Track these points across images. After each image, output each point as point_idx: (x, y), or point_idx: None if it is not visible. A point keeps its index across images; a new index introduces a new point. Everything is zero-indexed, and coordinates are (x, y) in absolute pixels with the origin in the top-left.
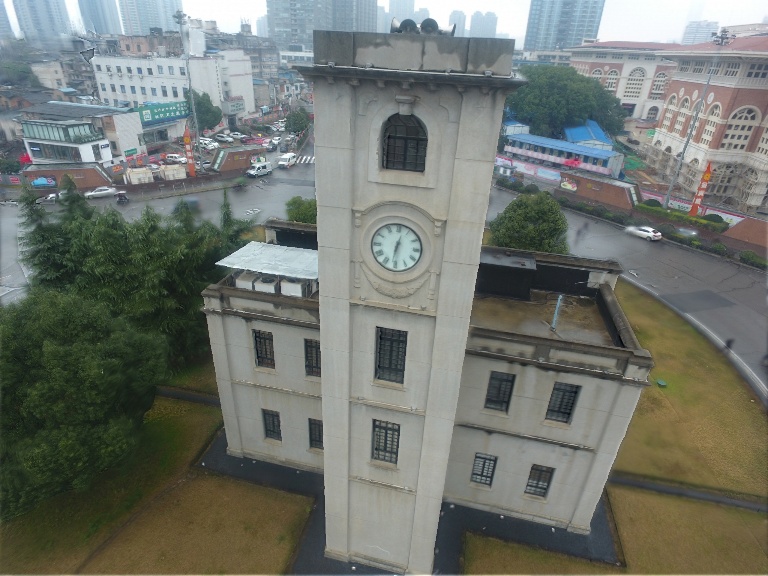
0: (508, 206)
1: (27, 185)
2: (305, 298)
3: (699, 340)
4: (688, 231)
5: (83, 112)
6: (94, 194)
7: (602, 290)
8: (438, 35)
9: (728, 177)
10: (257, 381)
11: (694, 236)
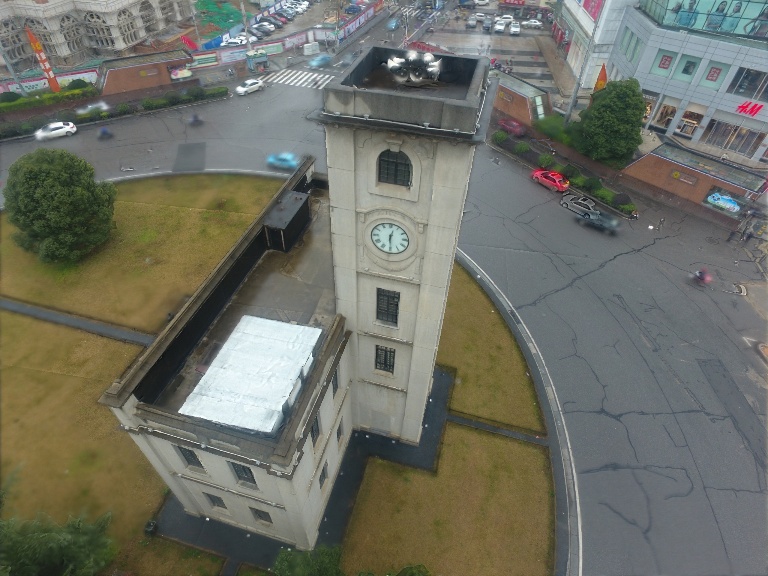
0: (20, 187)
1: None
2: (321, 353)
3: (243, 179)
4: (83, 107)
5: None
6: None
7: (319, 178)
8: (482, 72)
9: (14, 35)
10: (316, 463)
11: (96, 109)
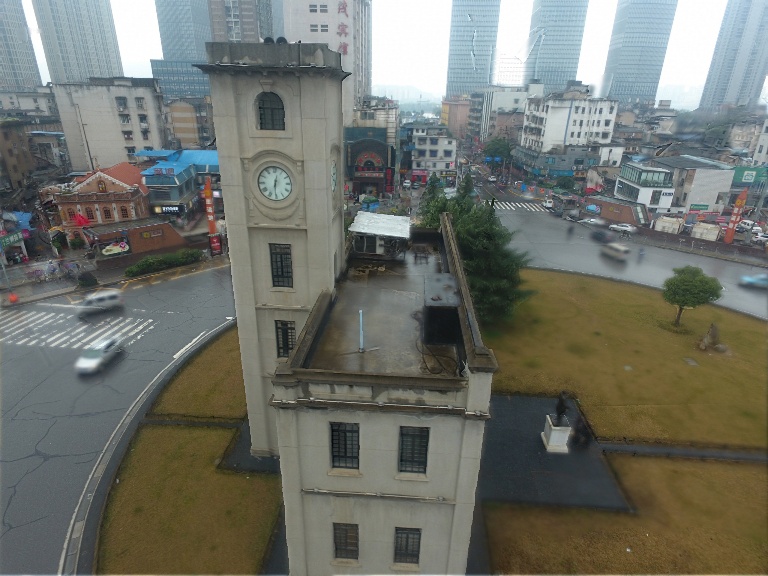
0: None
1: (584, 208)
2: (348, 243)
3: None
4: None
5: (689, 165)
6: (616, 227)
7: None
8: None
9: None
10: None
11: None
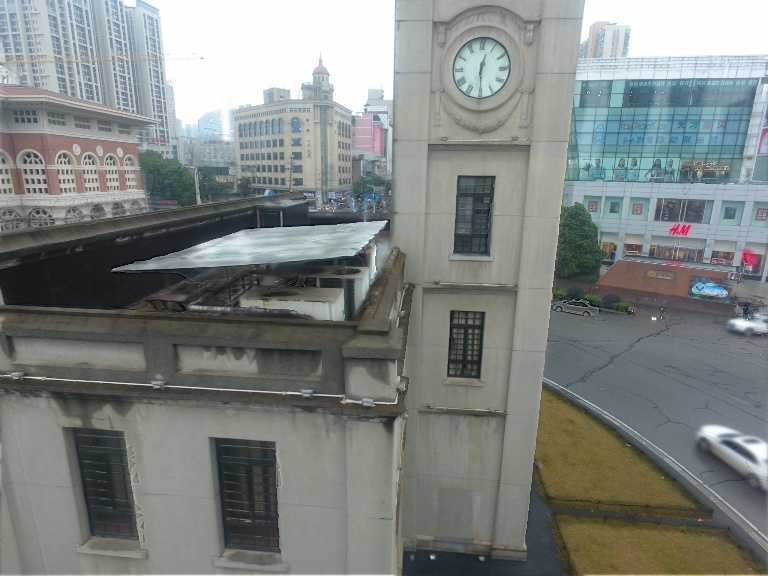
0: None
1: None
2: (388, 264)
3: None
4: None
5: None
6: None
7: (312, 215)
8: None
9: None
10: None
11: None
